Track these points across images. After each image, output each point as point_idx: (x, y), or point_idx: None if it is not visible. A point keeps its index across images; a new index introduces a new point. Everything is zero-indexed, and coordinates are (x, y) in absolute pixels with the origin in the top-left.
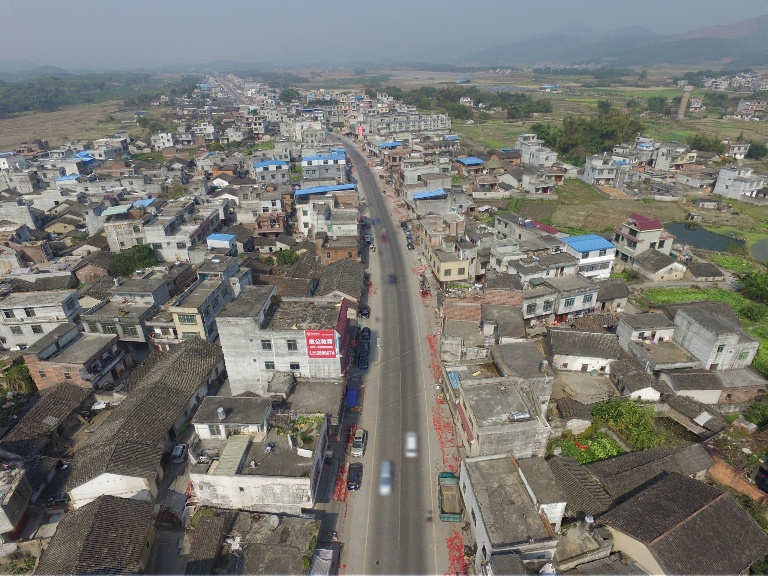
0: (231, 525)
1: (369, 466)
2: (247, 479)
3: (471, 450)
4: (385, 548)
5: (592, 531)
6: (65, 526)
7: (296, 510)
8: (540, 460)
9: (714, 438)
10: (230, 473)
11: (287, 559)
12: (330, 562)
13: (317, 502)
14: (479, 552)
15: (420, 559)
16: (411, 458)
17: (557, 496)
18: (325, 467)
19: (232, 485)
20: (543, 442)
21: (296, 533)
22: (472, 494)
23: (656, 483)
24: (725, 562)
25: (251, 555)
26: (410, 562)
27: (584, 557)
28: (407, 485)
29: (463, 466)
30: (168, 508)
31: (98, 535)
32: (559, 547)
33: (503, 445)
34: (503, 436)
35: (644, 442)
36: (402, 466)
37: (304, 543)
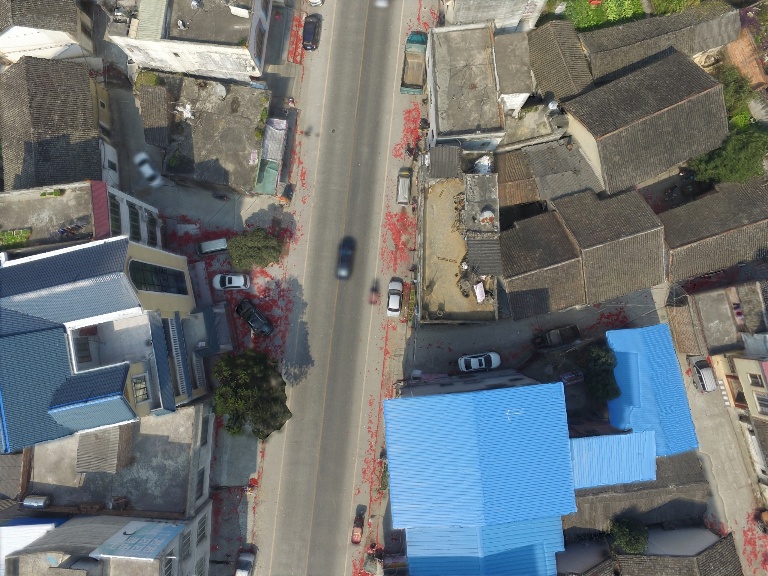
0: (178, 92)
1: (329, 19)
2: (177, 45)
3: (447, 12)
4: (341, 117)
5: (551, 116)
6: (4, 88)
7: (244, 77)
8: (521, 38)
9: (764, 2)
10: (155, 37)
11: (240, 130)
12: (284, 132)
13: (270, 64)
14: (430, 131)
15: (375, 129)
16: (380, 10)
17: (523, 86)
18: (276, 19)
19: (163, 50)
20: (539, 5)
21: (246, 104)
22: (432, 75)
23: (650, 65)
24: (665, 156)
25: (204, 124)
26: (365, 132)
27: (532, 141)
28: (371, 47)
29: (429, 38)
30: (111, 63)
31: (40, 102)
32: (511, 131)
33: (484, 12)
34: (485, 2)
35: (672, 4)
36: (368, 21)
37: (255, 114)
